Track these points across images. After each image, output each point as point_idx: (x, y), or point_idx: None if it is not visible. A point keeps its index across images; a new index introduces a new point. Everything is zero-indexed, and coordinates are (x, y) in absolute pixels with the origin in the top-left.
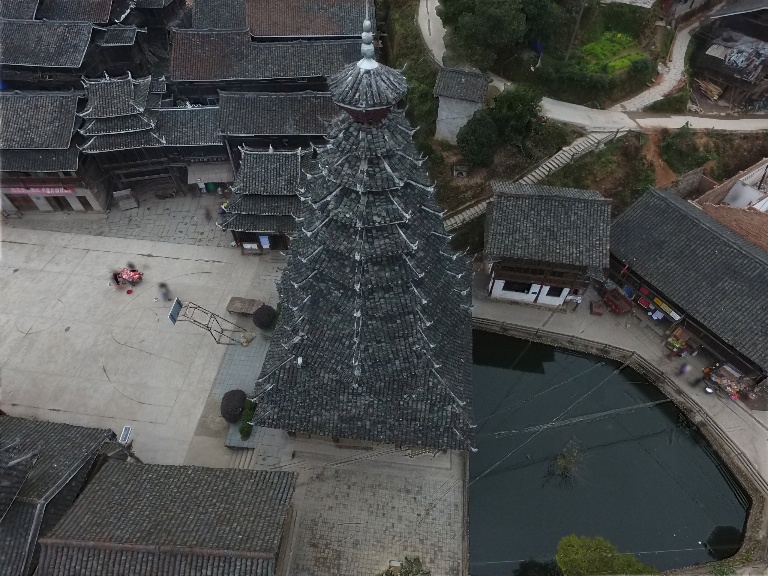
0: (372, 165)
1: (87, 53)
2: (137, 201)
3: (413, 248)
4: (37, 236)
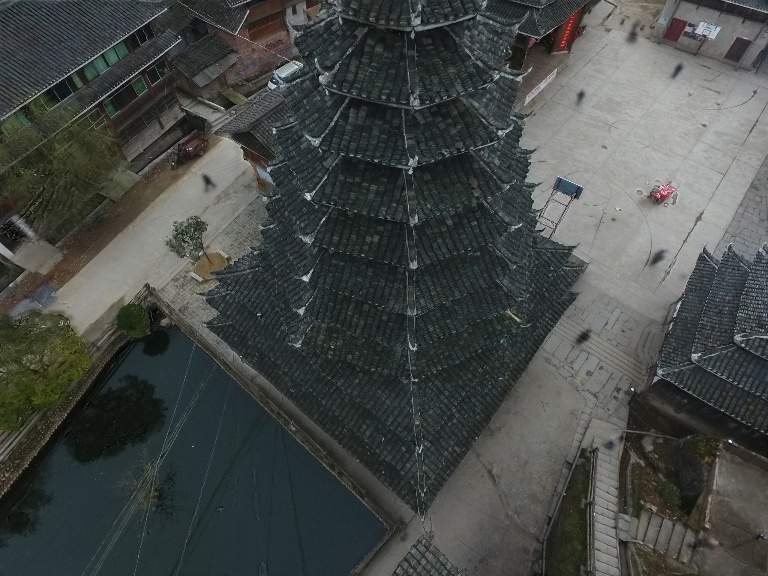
0: None
1: None
2: None
3: None
4: (761, 143)
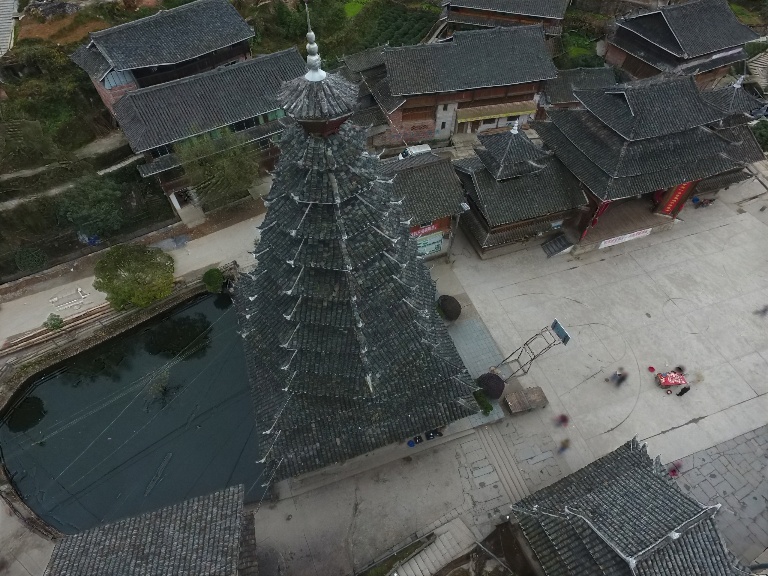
0: None
1: None
2: None
3: None
4: None
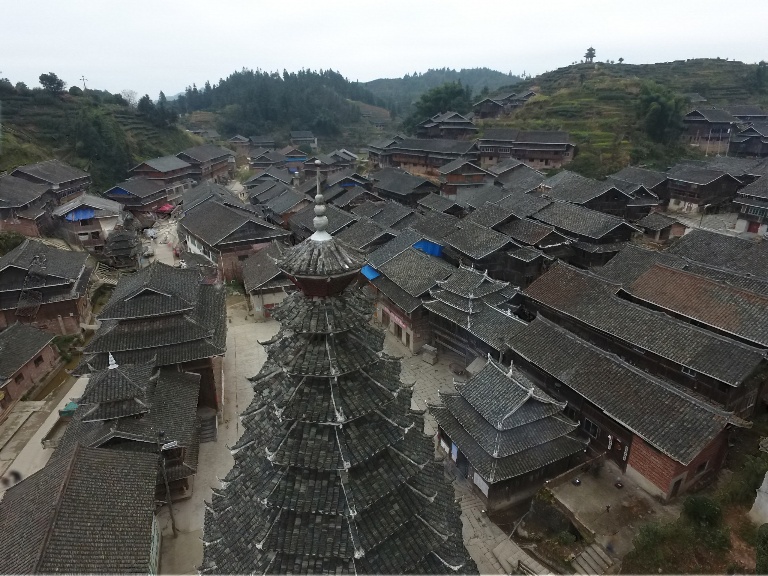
0: (295, 338)
1: (492, 254)
2: (437, 361)
3: (268, 456)
4: None
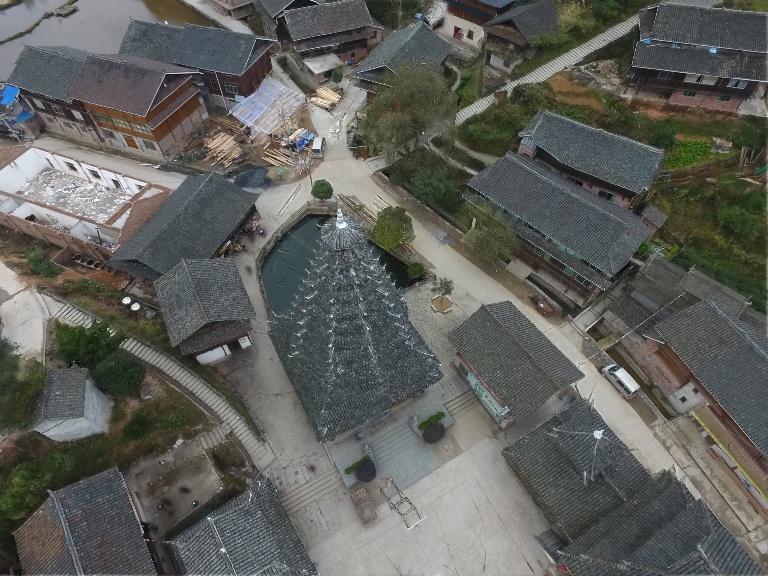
0: None
1: None
2: None
3: None
4: None
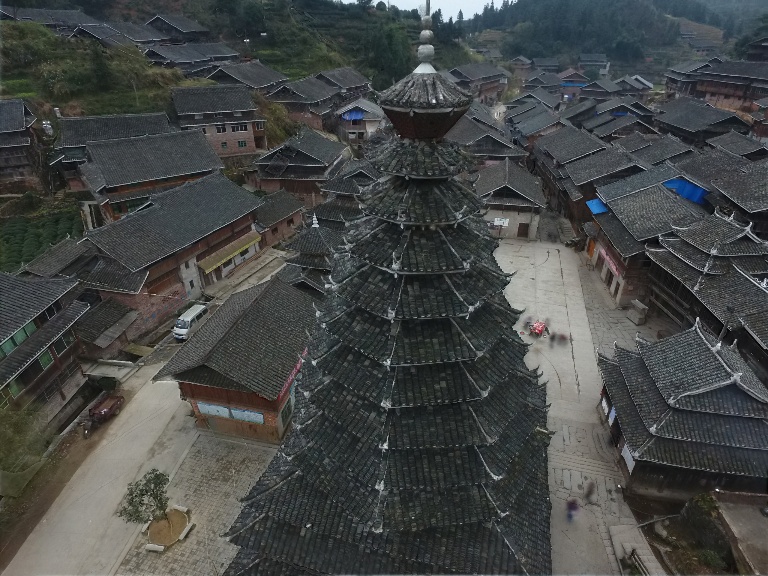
0: None
1: None
2: (644, 322)
3: None
4: (573, 281)
